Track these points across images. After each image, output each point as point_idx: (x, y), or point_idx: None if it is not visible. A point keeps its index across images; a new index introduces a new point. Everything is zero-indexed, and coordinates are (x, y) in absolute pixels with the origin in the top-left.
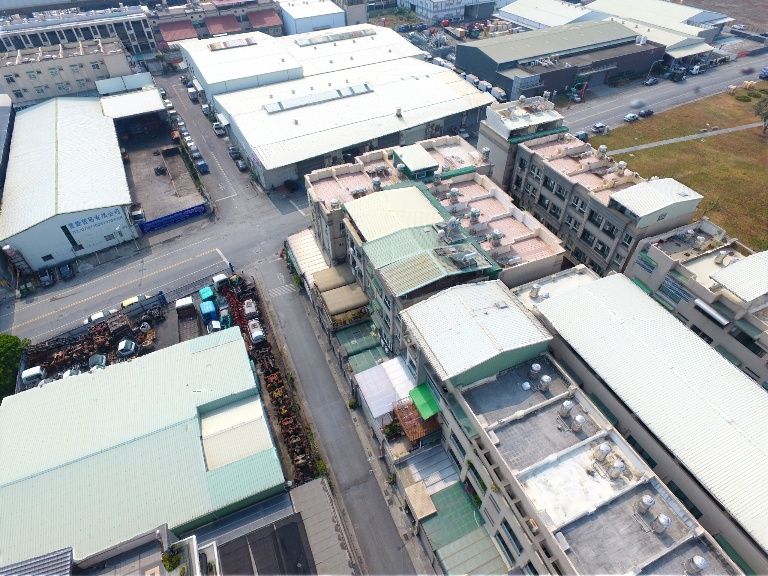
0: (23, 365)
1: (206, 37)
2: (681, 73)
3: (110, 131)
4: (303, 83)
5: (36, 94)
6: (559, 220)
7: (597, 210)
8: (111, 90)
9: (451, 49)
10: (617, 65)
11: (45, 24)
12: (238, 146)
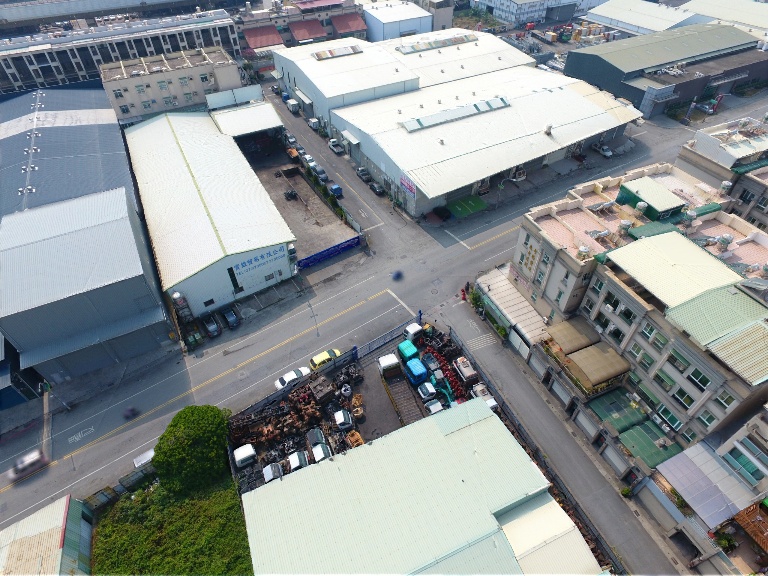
0: (227, 441)
1: (291, 43)
2: None
3: (236, 152)
4: (424, 96)
5: (143, 109)
6: None
7: None
8: (220, 104)
9: (551, 55)
10: (748, 73)
11: (131, 31)
12: (368, 166)
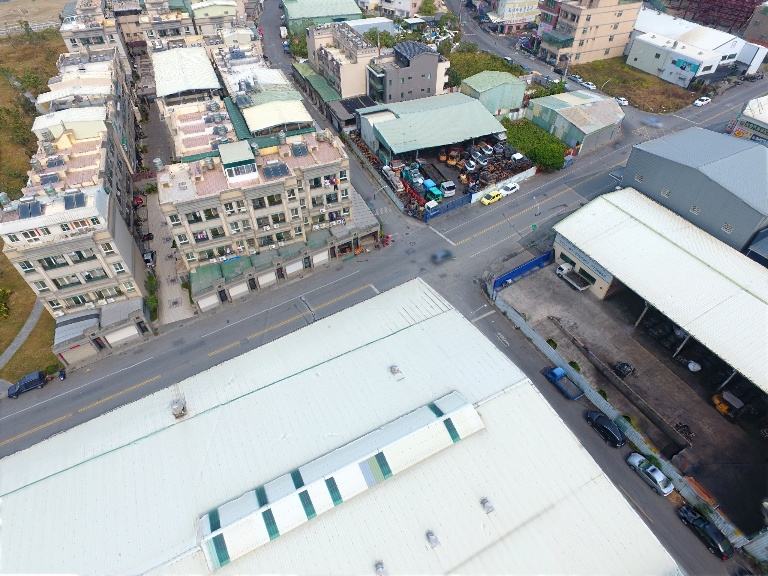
0: None
1: None
2: None
3: (760, 377)
4: None
5: None
6: None
7: None
8: None
9: None
10: None
11: None
12: None
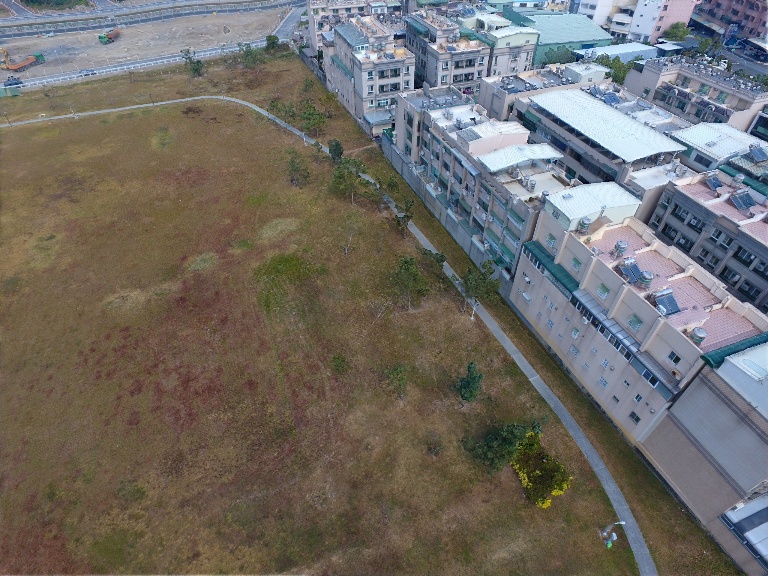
0: None
1: None
2: None
3: None
4: None
5: None
6: None
7: None
8: None
9: None
10: None
11: None
12: None
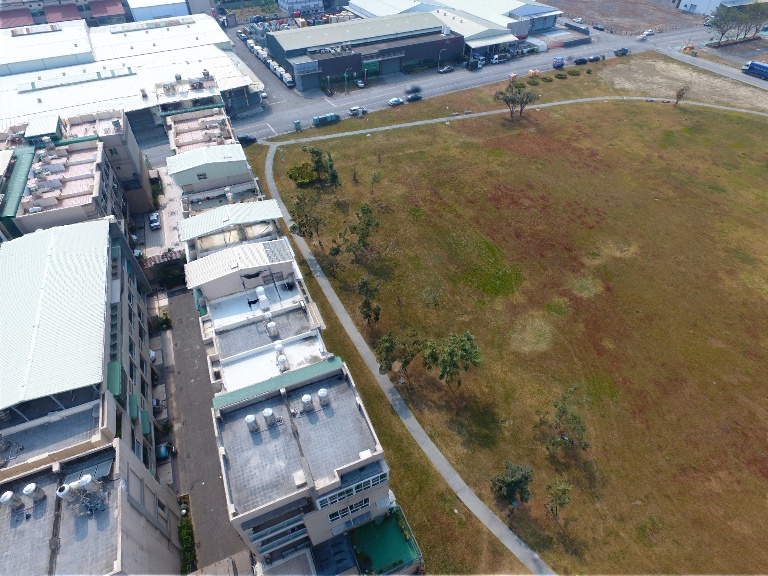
0: None
1: None
2: (473, 62)
3: None
4: (86, 67)
5: None
6: None
7: None
8: None
9: None
10: (406, 53)
11: None
12: None
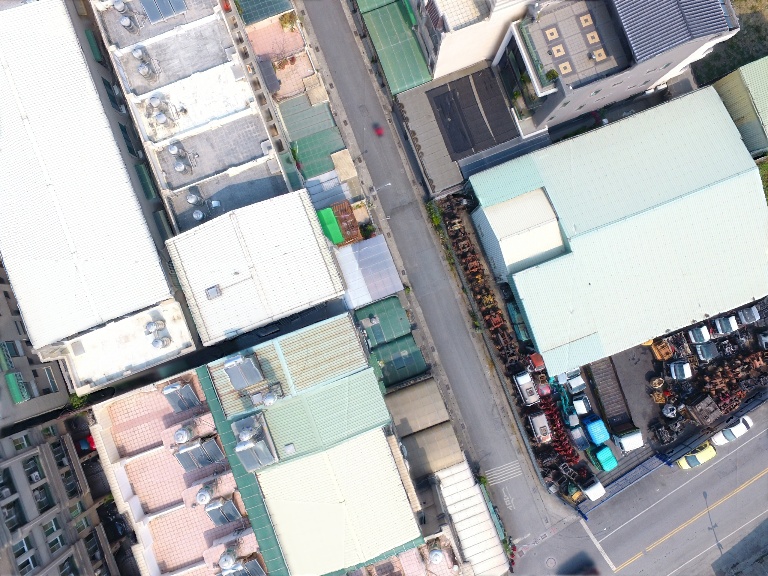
0: None
1: None
2: None
3: None
4: None
5: None
6: (71, 553)
7: (3, 524)
8: None
9: None
10: None
11: None
12: None
